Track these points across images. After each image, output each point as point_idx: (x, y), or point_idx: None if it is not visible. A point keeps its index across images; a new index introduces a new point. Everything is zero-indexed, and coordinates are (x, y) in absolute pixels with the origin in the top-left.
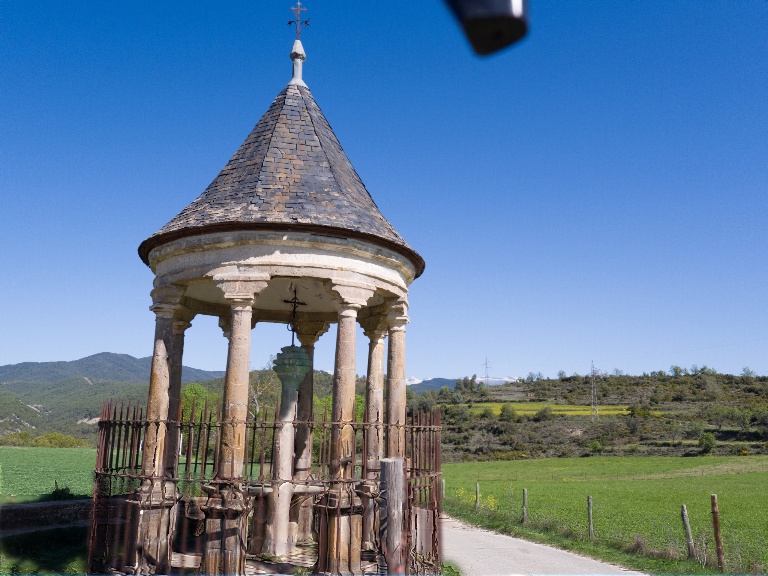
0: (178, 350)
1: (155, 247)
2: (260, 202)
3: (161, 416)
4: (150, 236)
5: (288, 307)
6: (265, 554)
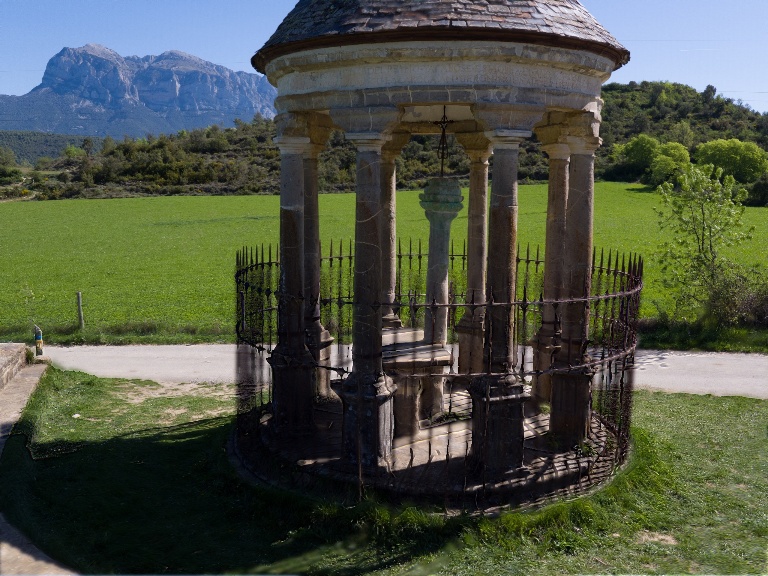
0: None
1: (533, 43)
2: None
3: None
4: None
5: None
6: (444, 413)
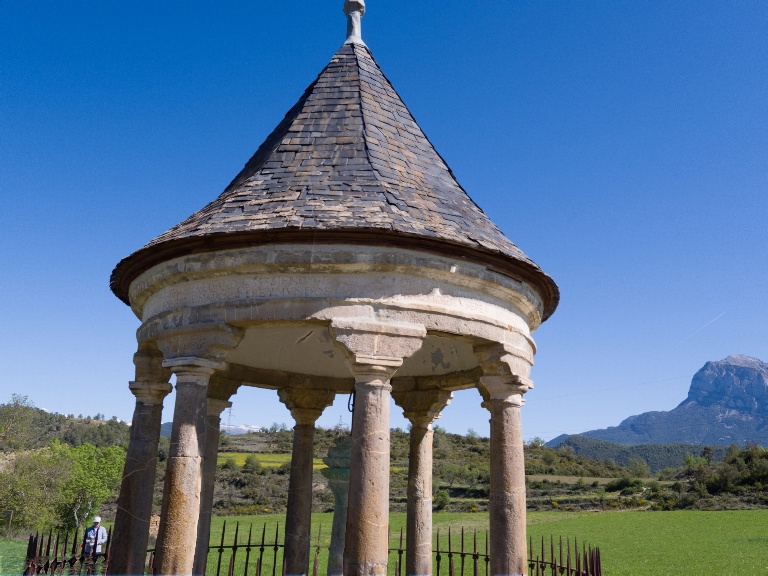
0: (154, 433)
1: (191, 253)
2: (402, 204)
3: (186, 575)
4: (196, 232)
5: (283, 365)
6: None
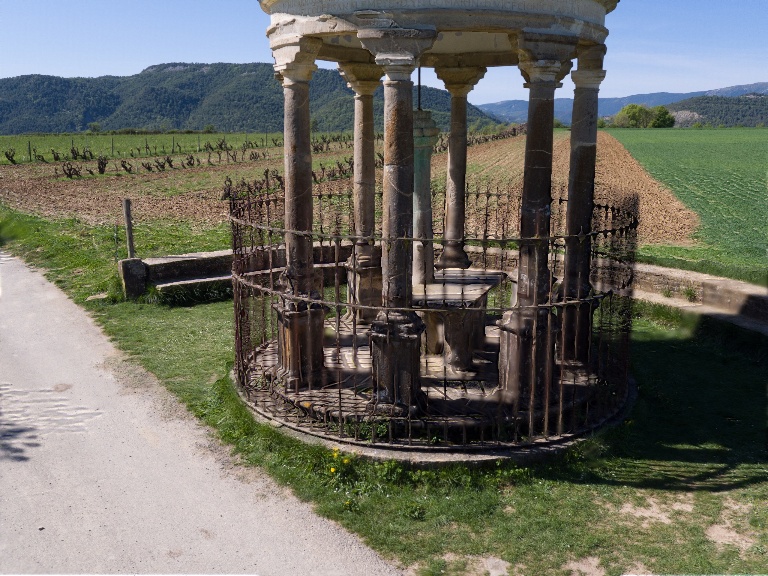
0: None
1: None
2: None
3: None
4: None
5: None
6: None
